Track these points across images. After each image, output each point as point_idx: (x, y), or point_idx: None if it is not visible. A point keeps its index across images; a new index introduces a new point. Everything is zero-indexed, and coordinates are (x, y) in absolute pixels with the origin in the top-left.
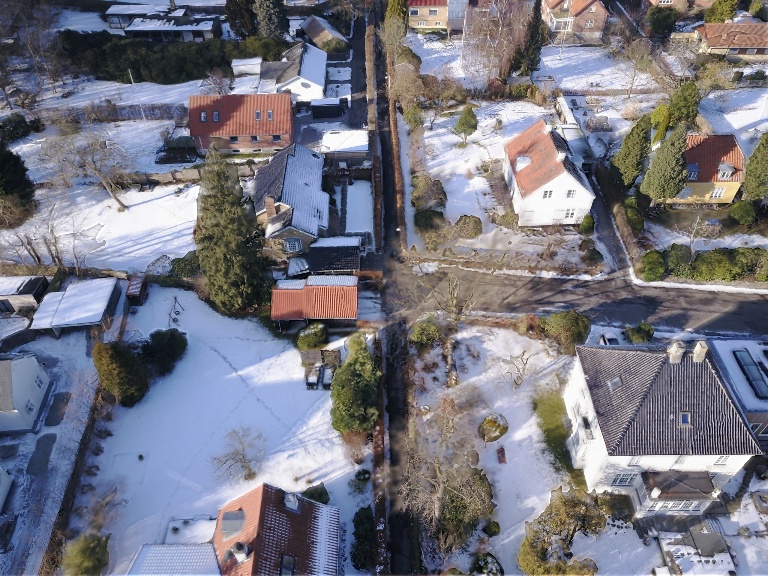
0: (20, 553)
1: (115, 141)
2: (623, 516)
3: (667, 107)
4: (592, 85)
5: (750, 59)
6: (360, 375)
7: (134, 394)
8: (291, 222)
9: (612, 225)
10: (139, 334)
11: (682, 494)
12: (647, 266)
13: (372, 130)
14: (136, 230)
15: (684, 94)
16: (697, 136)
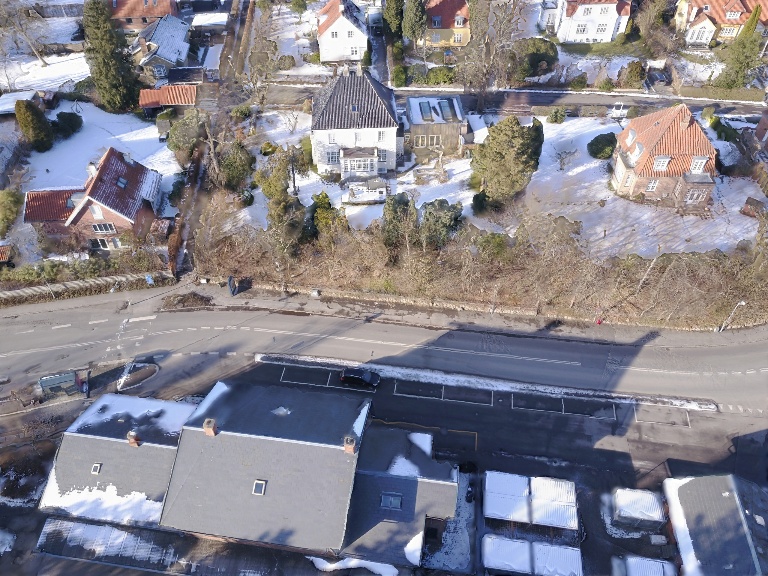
0: None
1: (42, 29)
2: (334, 180)
3: None
4: None
5: None
6: (189, 124)
7: (44, 139)
8: (156, 53)
9: (385, 60)
10: (49, 113)
11: (358, 155)
12: (394, 75)
13: (233, 14)
14: (54, 75)
15: None
16: None
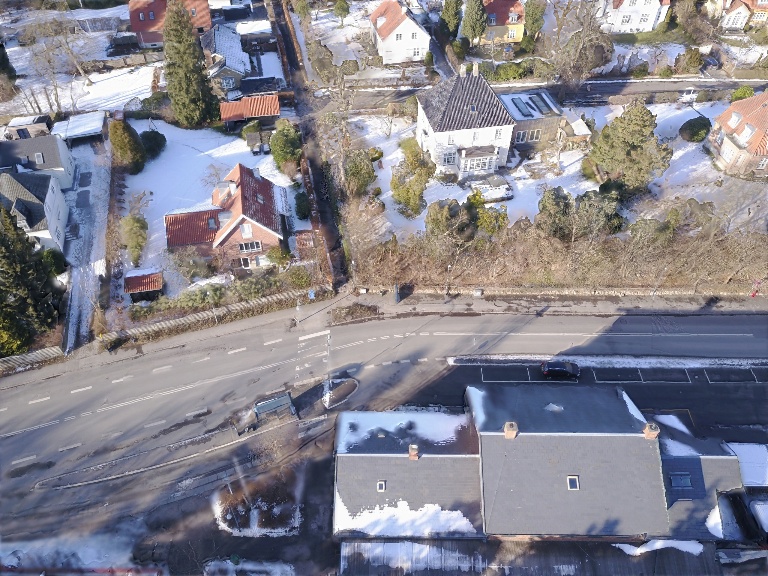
0: (87, 238)
1: None
2: (452, 181)
3: None
4: None
5: None
6: (287, 135)
7: (139, 161)
8: (225, 64)
9: (446, 60)
10: None
11: (478, 155)
12: None
13: (272, 21)
14: (106, 94)
15: None
16: None
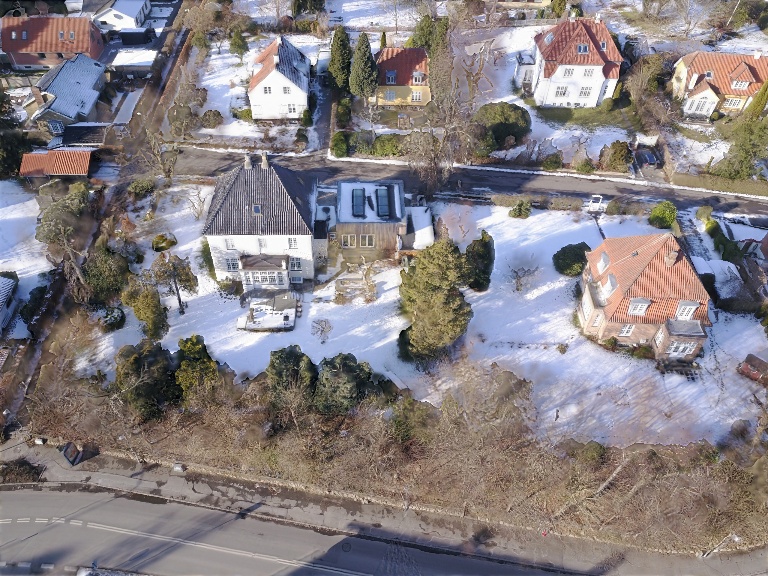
0: None
1: None
2: (235, 292)
3: (412, 37)
4: (372, 24)
5: (509, 6)
6: (68, 206)
7: None
8: (50, 106)
9: (330, 120)
10: None
11: (262, 267)
12: (333, 143)
13: (164, 51)
14: None
15: (421, 25)
16: (395, 48)
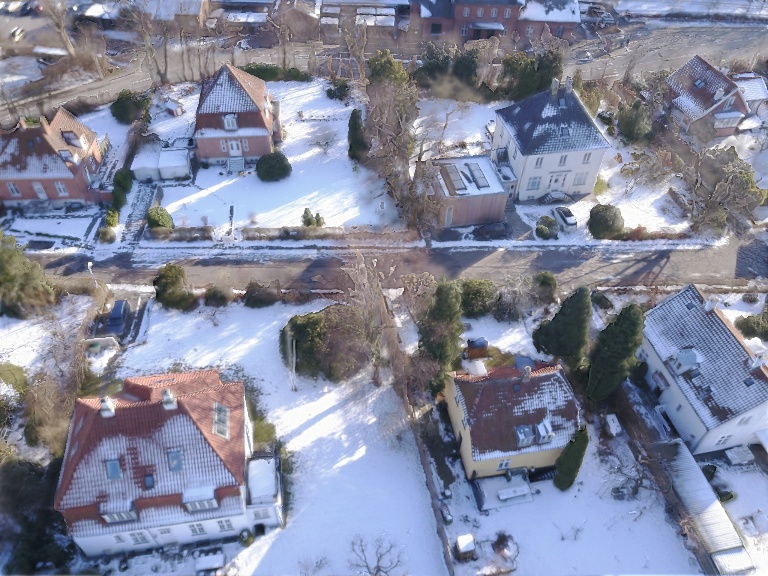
0: None
1: None
2: None
3: None
4: None
5: None
6: None
7: None
8: None
9: None
10: None
11: None
12: None
13: None
14: None
15: None
16: (538, 375)
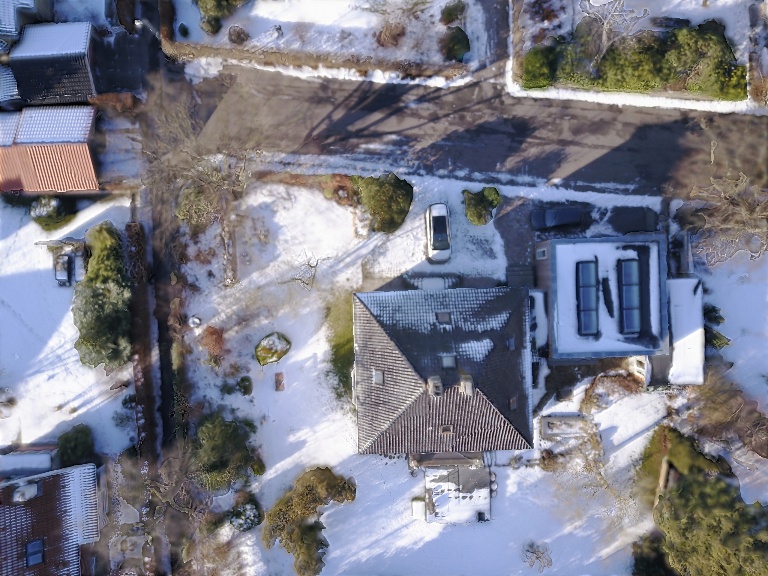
0: None
1: None
2: None
3: None
4: None
5: None
6: (104, 295)
7: None
8: None
9: None
10: None
11: (446, 461)
12: (524, 75)
13: None
14: None
15: None
16: None
